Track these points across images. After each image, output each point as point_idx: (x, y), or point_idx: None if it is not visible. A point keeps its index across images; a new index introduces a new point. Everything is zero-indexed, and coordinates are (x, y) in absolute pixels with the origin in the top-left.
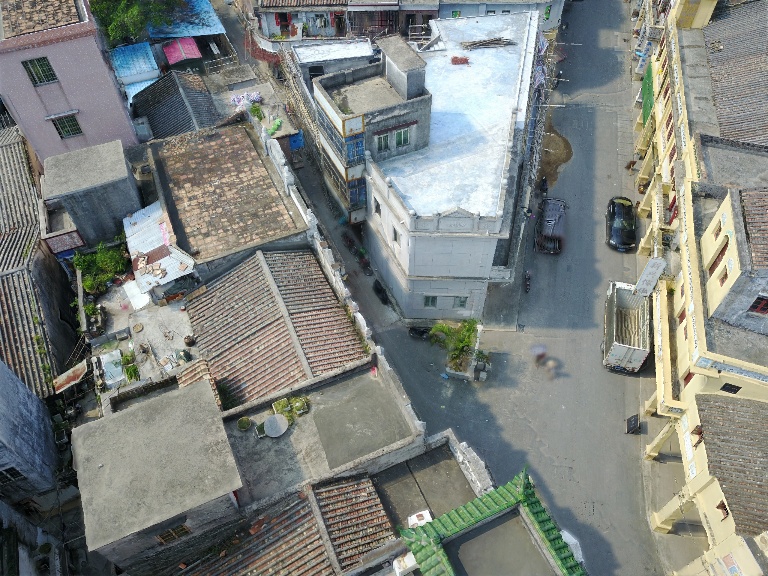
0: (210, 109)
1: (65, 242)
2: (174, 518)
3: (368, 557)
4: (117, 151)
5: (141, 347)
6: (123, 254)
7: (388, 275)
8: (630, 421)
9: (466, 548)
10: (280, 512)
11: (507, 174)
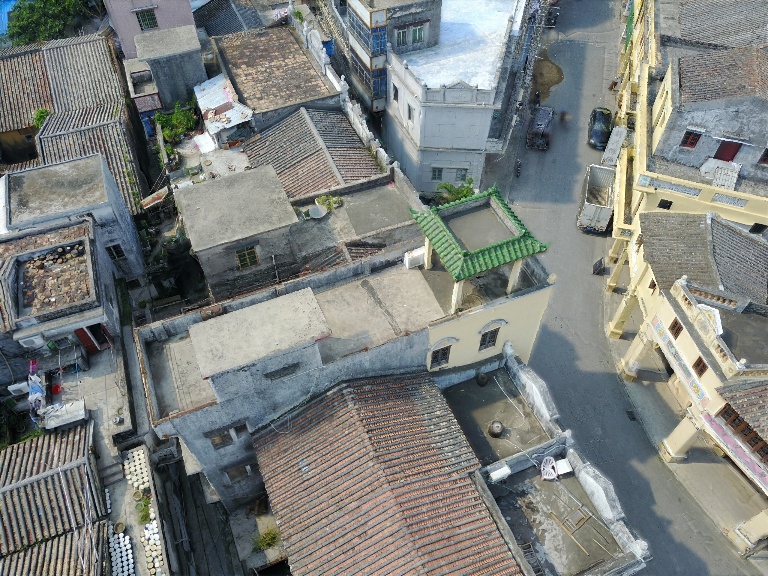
0: (257, 21)
1: (148, 103)
2: (251, 240)
3: (388, 248)
4: (191, 31)
5: (211, 173)
6: (193, 116)
7: (402, 157)
8: (596, 264)
9: (454, 221)
10: (321, 262)
11: (501, 61)
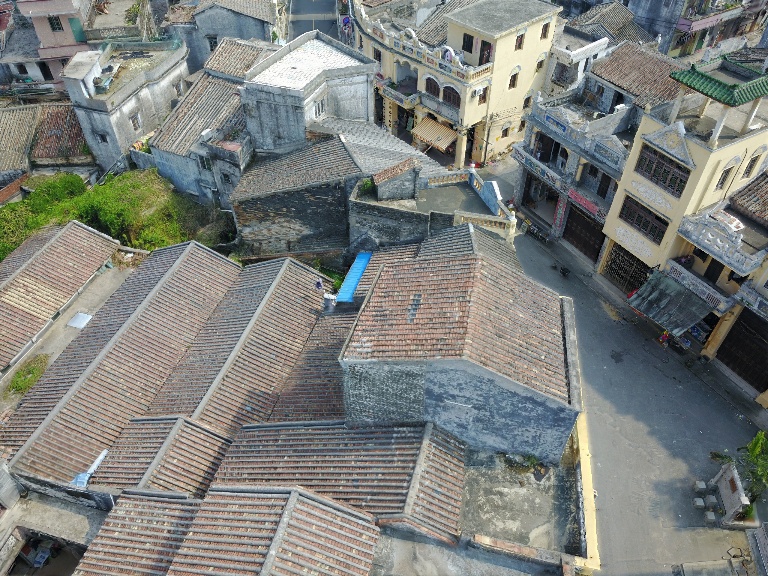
0: None
1: None
2: None
3: None
4: None
5: None
6: None
7: None
8: None
9: None
10: None
11: None
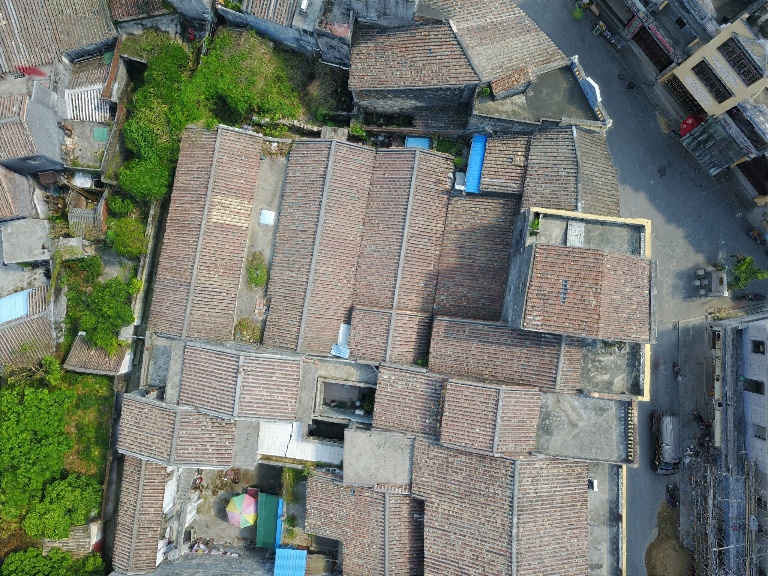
0: None
1: None
2: None
3: None
4: None
5: None
6: None
7: None
8: None
9: None
10: None
11: None
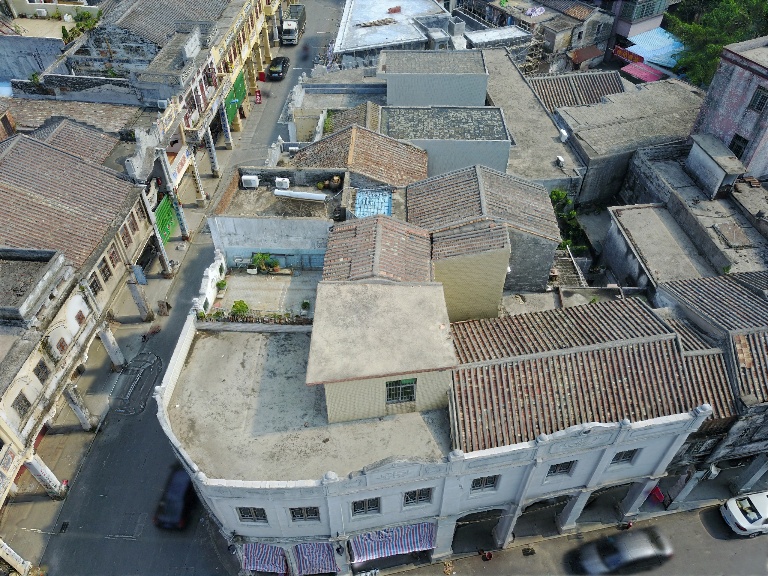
0: (551, 3)
1: None
2: None
3: None
4: None
5: None
6: None
7: None
8: None
9: None
10: None
11: None
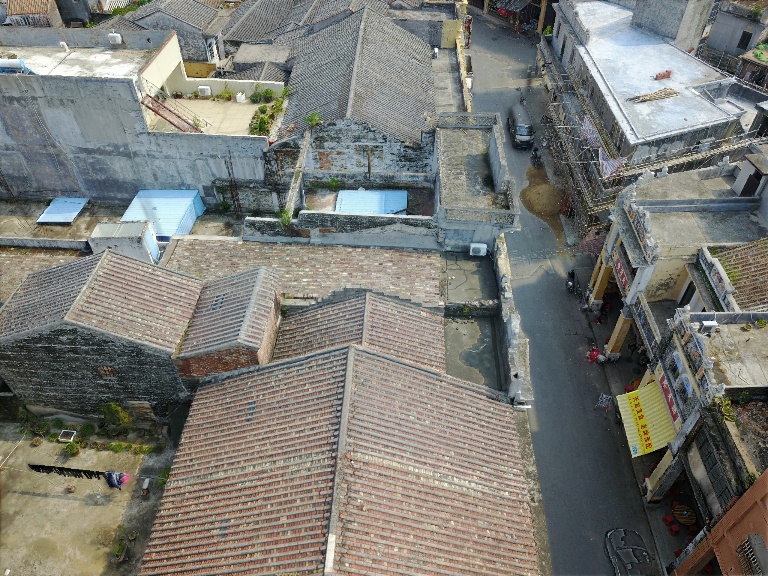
0: None
1: None
2: None
3: None
4: None
5: None
6: None
7: None
8: None
9: None
10: None
11: None
